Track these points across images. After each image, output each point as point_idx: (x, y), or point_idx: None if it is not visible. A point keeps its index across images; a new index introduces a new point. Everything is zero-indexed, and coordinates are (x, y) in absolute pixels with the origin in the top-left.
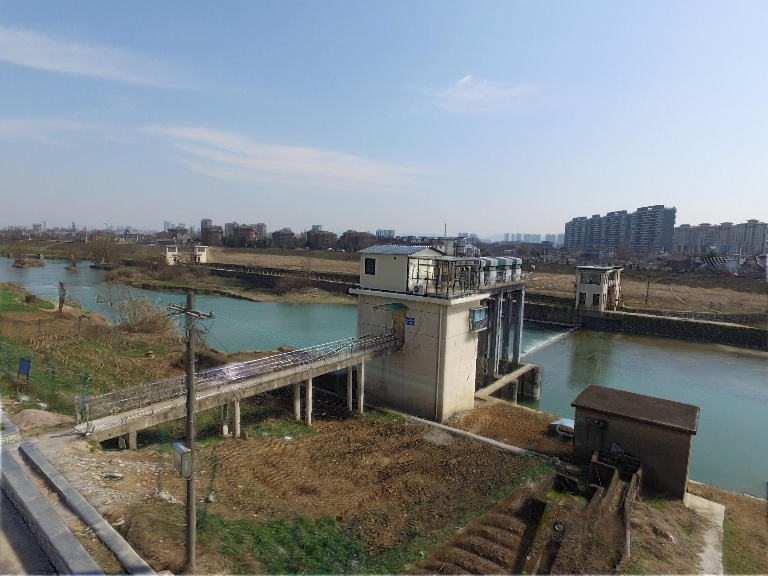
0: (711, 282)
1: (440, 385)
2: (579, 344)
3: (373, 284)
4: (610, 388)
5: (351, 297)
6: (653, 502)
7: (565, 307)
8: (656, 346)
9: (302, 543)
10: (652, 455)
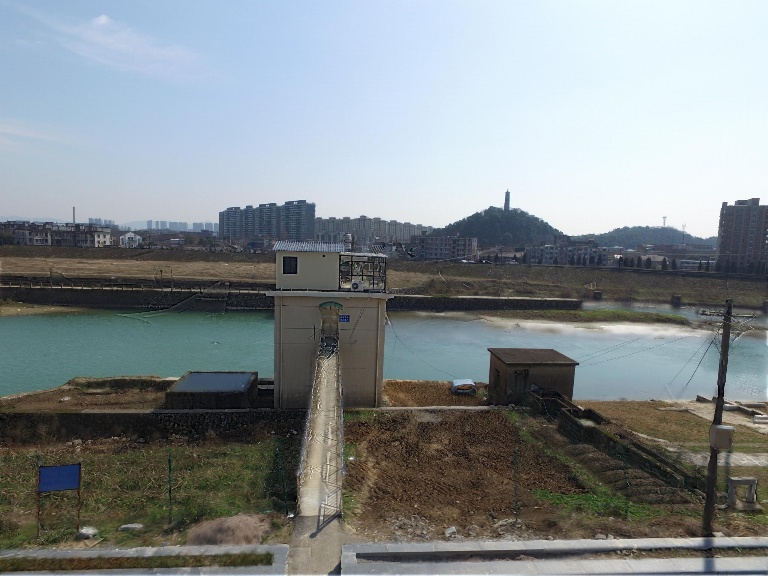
0: None
1: (379, 374)
2: None
3: (295, 284)
4: None
5: (29, 305)
6: None
7: None
8: None
9: (595, 505)
10: (555, 385)
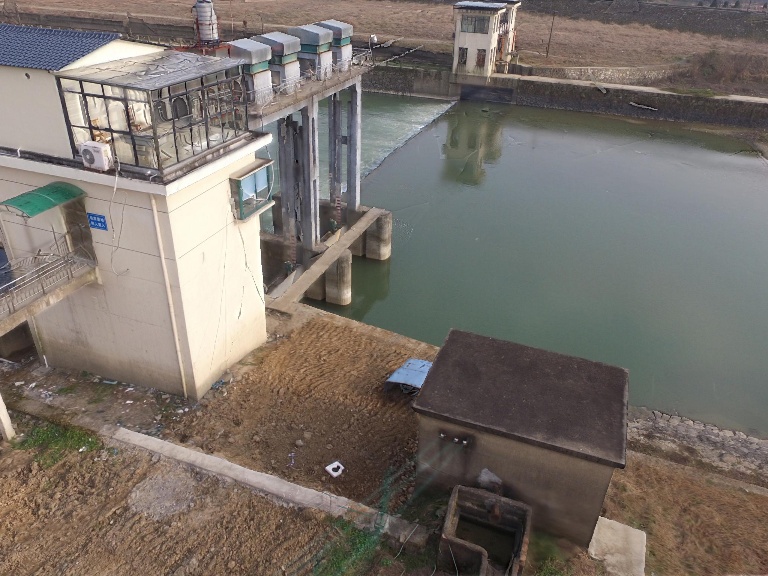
0: (627, 14)
1: (182, 342)
2: (457, 127)
3: None
4: (486, 337)
5: None
6: (543, 575)
7: (439, 71)
8: (555, 129)
9: None
10: (547, 489)
